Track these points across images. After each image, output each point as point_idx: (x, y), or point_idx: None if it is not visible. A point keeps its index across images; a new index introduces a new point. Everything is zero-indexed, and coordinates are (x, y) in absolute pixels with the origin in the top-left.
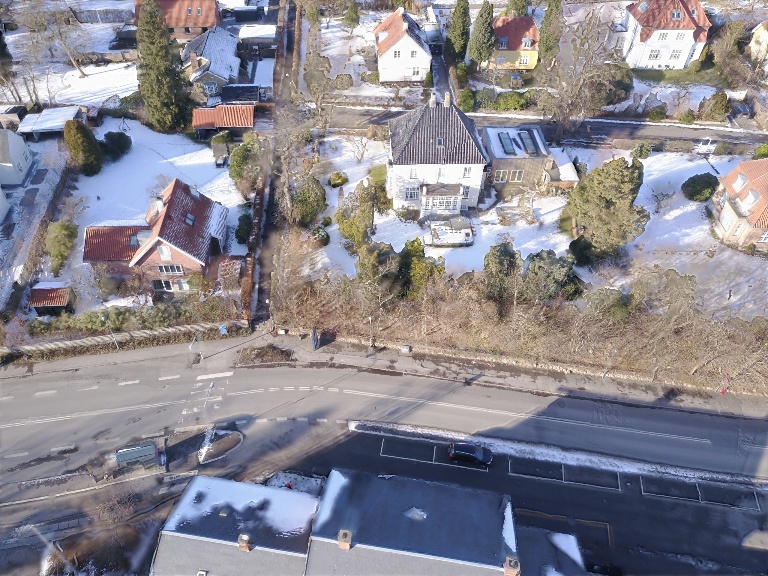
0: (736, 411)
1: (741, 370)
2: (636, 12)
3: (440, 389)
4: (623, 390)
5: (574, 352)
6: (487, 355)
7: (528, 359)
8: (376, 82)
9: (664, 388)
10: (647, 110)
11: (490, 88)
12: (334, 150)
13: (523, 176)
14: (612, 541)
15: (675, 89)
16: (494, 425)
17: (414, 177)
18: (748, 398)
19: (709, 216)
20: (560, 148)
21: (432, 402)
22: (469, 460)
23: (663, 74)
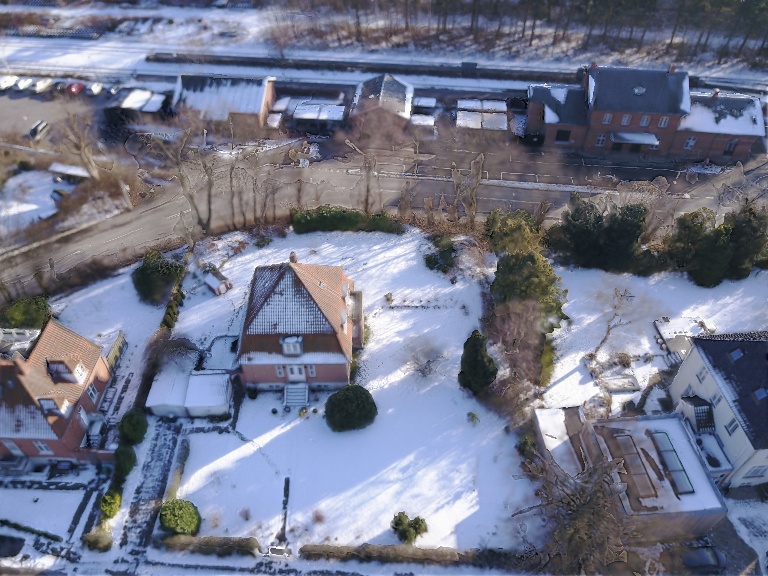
0: None
1: None
2: None
3: None
4: None
5: None
6: None
7: None
8: None
9: None
10: None
11: None
12: None
13: None
14: (509, 156)
15: None
16: (587, 199)
17: None
18: None
19: (356, 368)
20: None
21: None
22: None
23: None
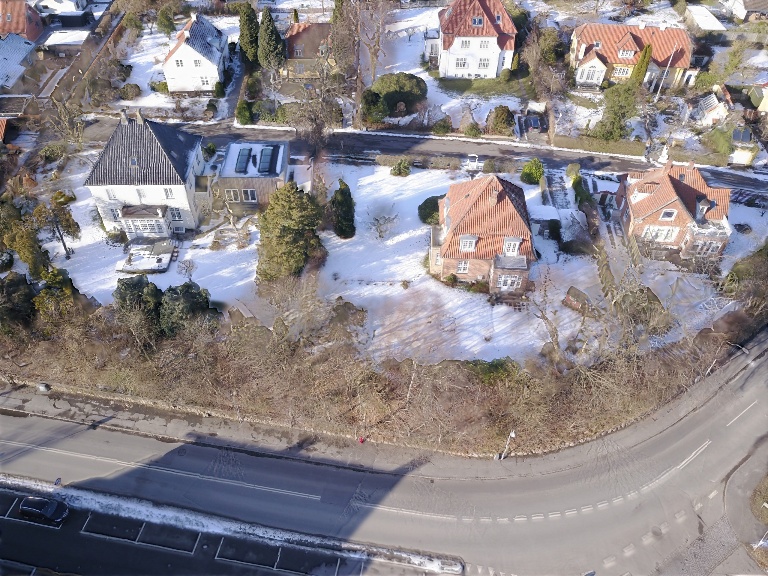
0: (366, 463)
1: (383, 417)
2: (443, 18)
3: (59, 433)
4: (256, 437)
5: (214, 394)
6: (123, 395)
7: (166, 400)
8: (165, 92)
9: (302, 435)
10: (430, 123)
11: (274, 99)
12: (81, 166)
13: (256, 196)
14: None
15: (476, 100)
16: (94, 475)
17: (114, 198)
18: (387, 448)
19: None
20: (307, 165)
21: (41, 448)
22: (37, 516)
23: (471, 84)
